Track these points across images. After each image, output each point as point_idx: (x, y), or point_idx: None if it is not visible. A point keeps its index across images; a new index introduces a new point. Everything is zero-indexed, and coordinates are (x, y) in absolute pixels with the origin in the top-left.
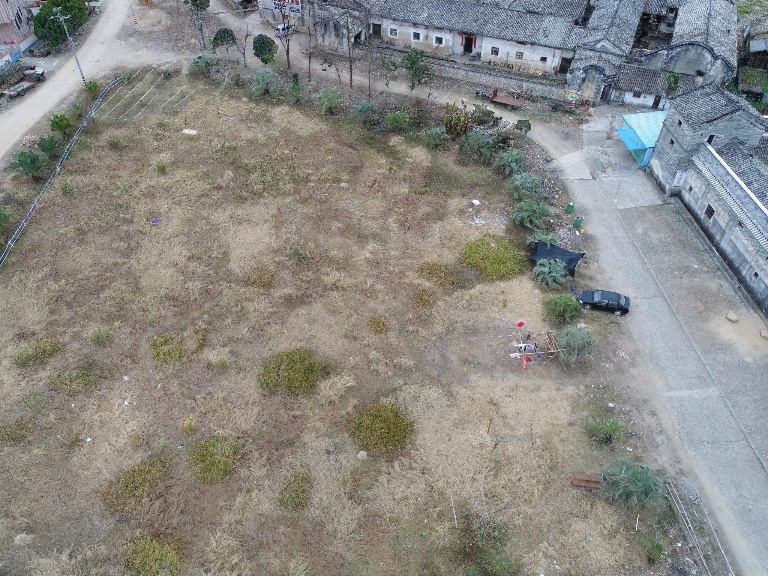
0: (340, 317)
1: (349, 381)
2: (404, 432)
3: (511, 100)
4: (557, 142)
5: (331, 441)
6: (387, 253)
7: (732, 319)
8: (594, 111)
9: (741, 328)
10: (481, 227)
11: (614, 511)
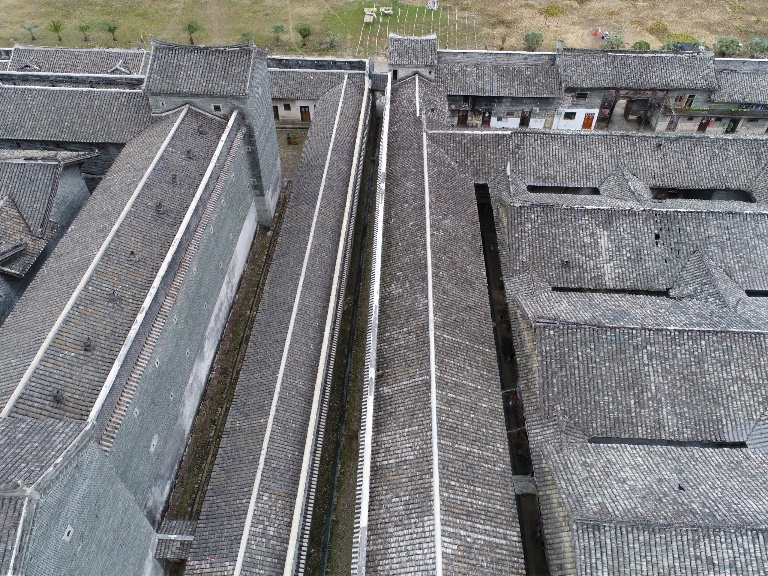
0: (615, 6)
1: (576, 6)
2: (552, 13)
3: None
4: None
5: (545, 4)
6: None
7: None
8: None
9: None
10: (711, 42)
11: (522, 48)
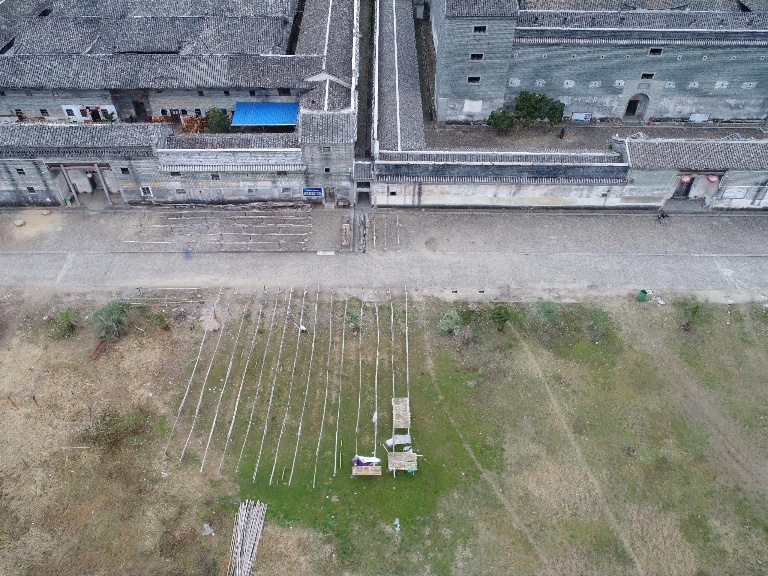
0: None
1: None
2: None
3: None
4: None
5: None
6: None
7: (21, 223)
8: None
9: (32, 223)
10: None
11: (126, 340)
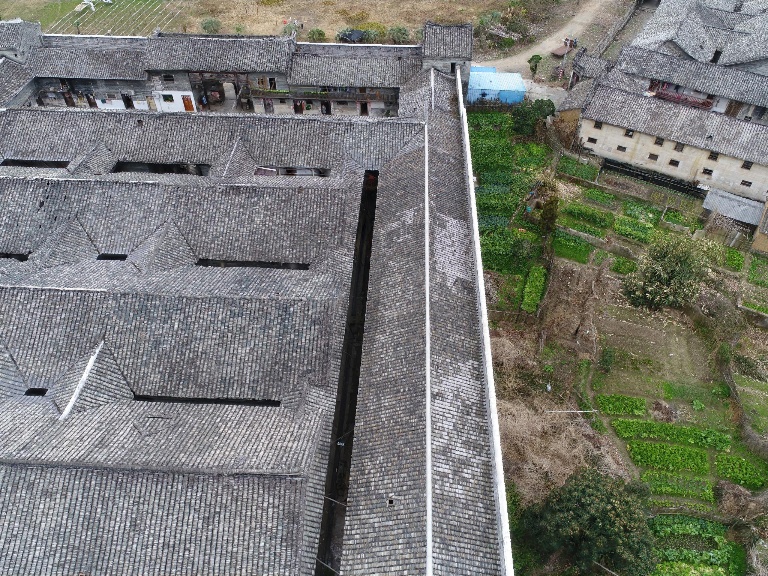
0: None
1: None
2: (267, 3)
3: (563, 51)
4: (502, 67)
5: None
6: (381, 7)
7: None
8: (559, 89)
9: None
10: None
11: None
